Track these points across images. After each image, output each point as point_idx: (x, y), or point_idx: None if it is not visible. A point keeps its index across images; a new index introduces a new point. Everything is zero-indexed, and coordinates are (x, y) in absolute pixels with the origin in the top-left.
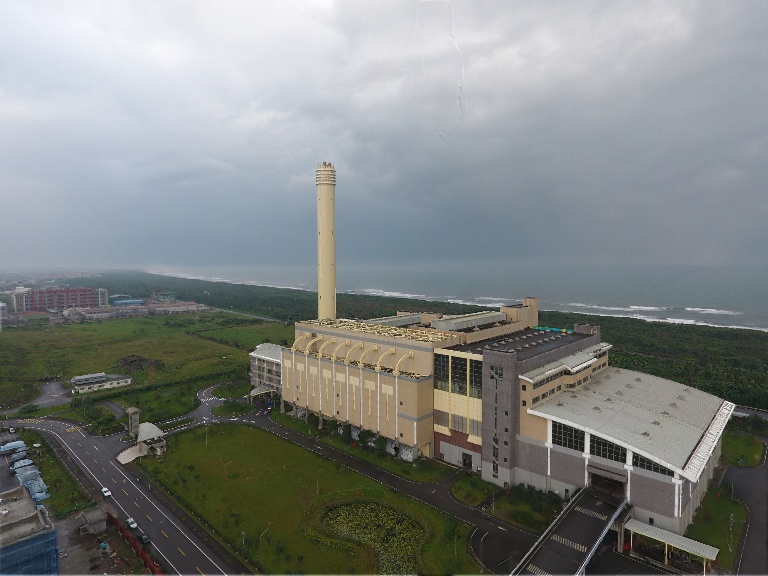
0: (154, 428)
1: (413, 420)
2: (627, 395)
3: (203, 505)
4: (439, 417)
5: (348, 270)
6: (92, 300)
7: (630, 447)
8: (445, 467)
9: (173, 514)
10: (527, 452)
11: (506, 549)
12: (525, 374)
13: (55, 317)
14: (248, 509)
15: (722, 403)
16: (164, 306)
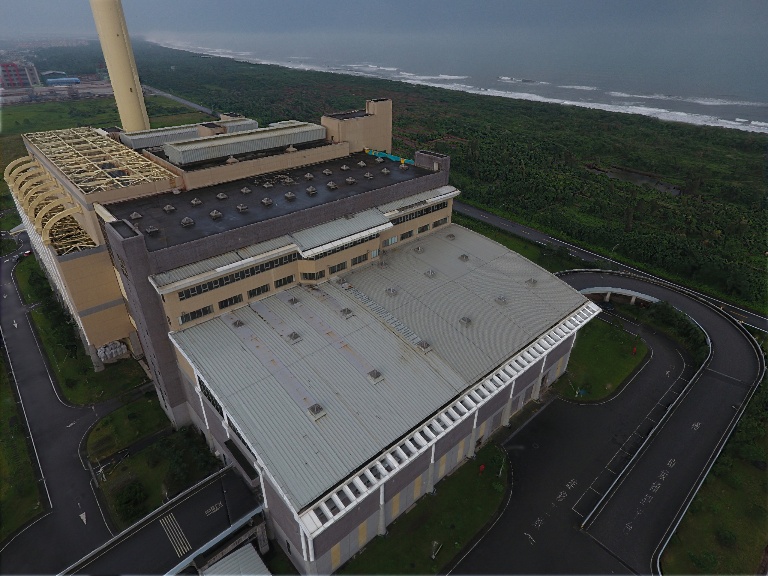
0: None
1: (77, 313)
2: (403, 295)
3: None
4: (128, 307)
5: (334, 40)
6: (19, 78)
7: (248, 445)
8: (135, 376)
9: None
10: (188, 389)
11: (39, 569)
12: (165, 274)
13: None
14: None
15: (578, 307)
16: (88, 87)
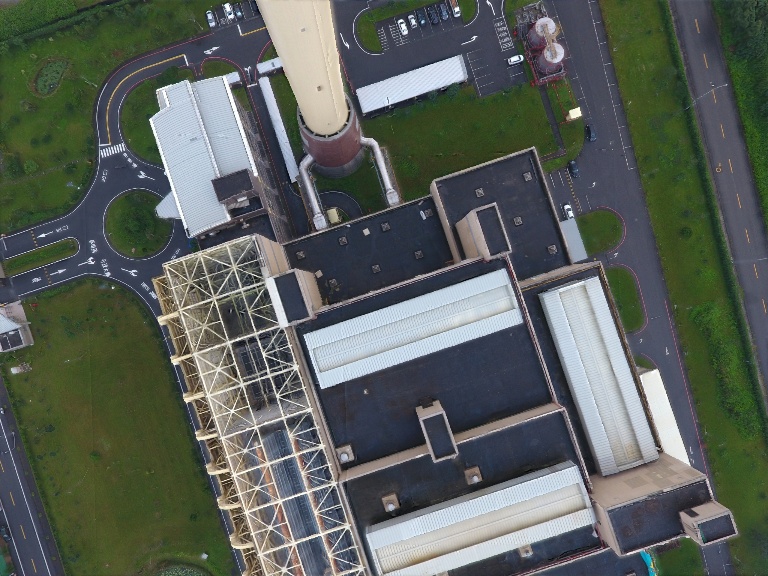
0: (3, 320)
1: None
2: None
3: (58, 502)
4: None
5: None
6: None
7: None
8: None
9: (32, 501)
10: None
11: None
12: None
13: None
14: (95, 531)
15: None
16: None
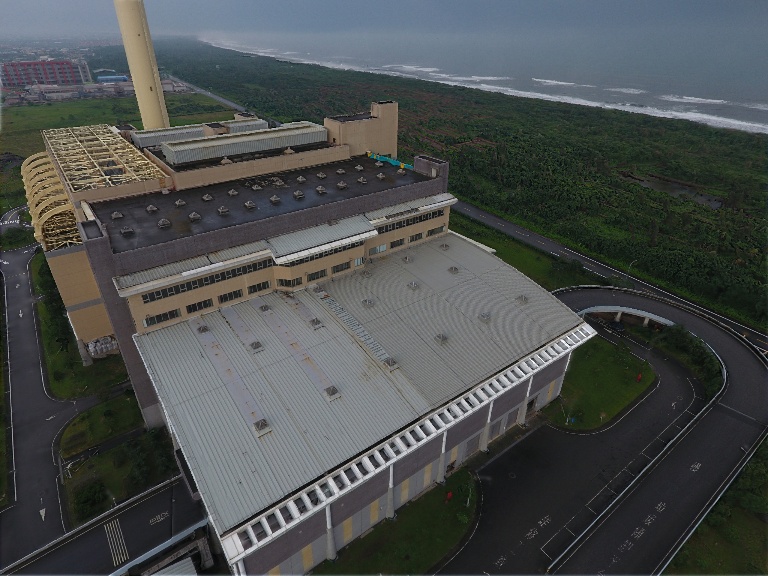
0: None
1: None
2: (379, 308)
3: None
4: None
5: (374, 40)
6: (73, 75)
7: None
8: (120, 372)
9: None
10: None
11: None
12: (129, 276)
13: (11, 96)
14: None
15: (571, 329)
16: None
